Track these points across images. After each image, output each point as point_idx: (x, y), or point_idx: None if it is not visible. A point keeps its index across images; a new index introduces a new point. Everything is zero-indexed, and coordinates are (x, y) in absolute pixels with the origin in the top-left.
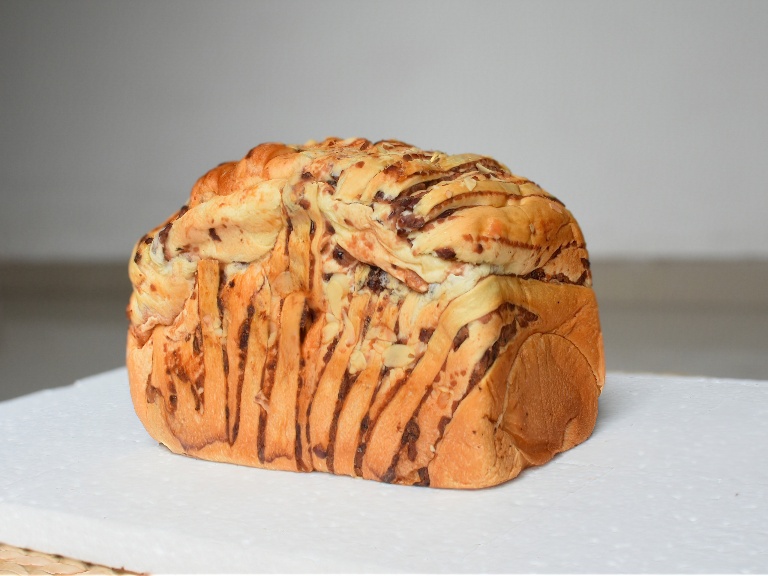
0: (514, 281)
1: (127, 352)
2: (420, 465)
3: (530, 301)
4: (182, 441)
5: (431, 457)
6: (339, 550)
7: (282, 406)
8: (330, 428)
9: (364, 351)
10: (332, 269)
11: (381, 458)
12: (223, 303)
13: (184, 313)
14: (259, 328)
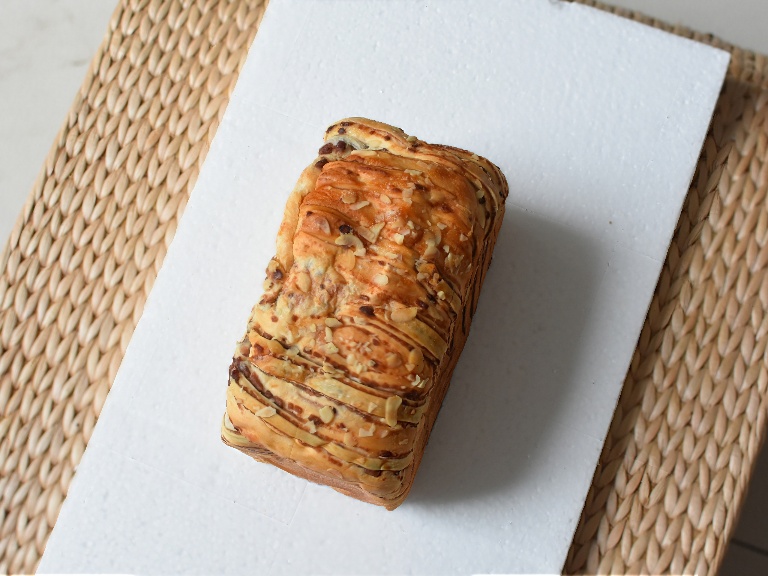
0: None
1: None
2: None
3: None
4: None
5: None
6: (129, 376)
7: None
8: None
9: None
10: None
11: None
12: None
13: None
14: None
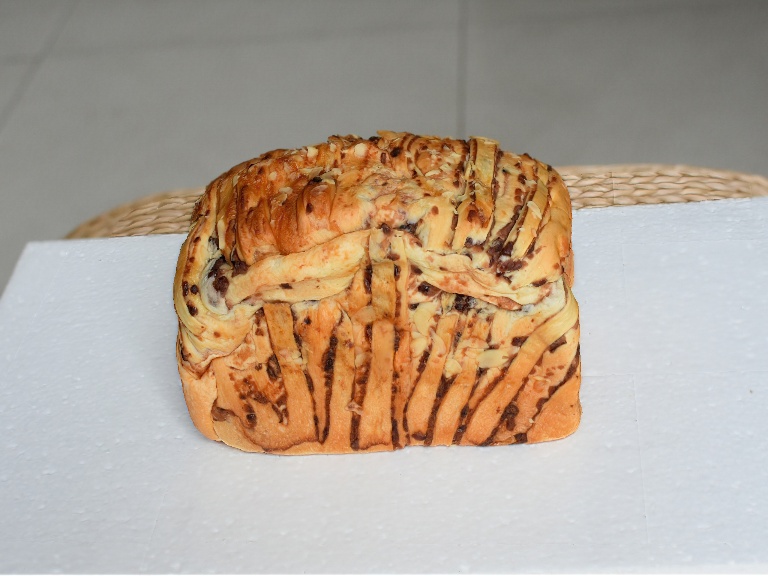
0: None
1: (185, 385)
2: (518, 432)
3: None
4: (265, 447)
5: (529, 426)
6: (549, 556)
7: (376, 409)
8: (429, 419)
9: (458, 359)
10: (419, 300)
11: (481, 433)
12: (301, 338)
13: (252, 348)
14: (346, 354)
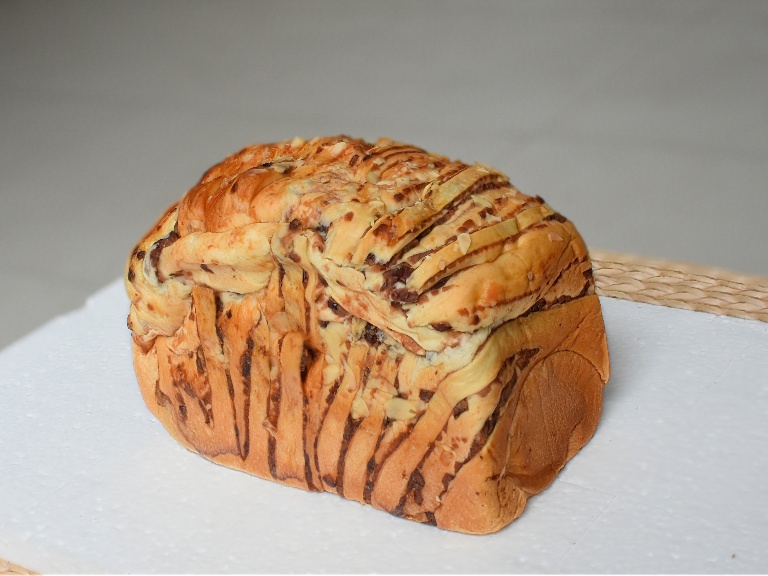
0: (513, 326)
1: None
2: (427, 509)
3: (531, 339)
4: (196, 447)
5: (437, 505)
6: None
7: (289, 435)
8: (338, 463)
9: (366, 399)
10: (328, 318)
11: (389, 497)
12: (222, 332)
13: (184, 332)
14: (260, 362)
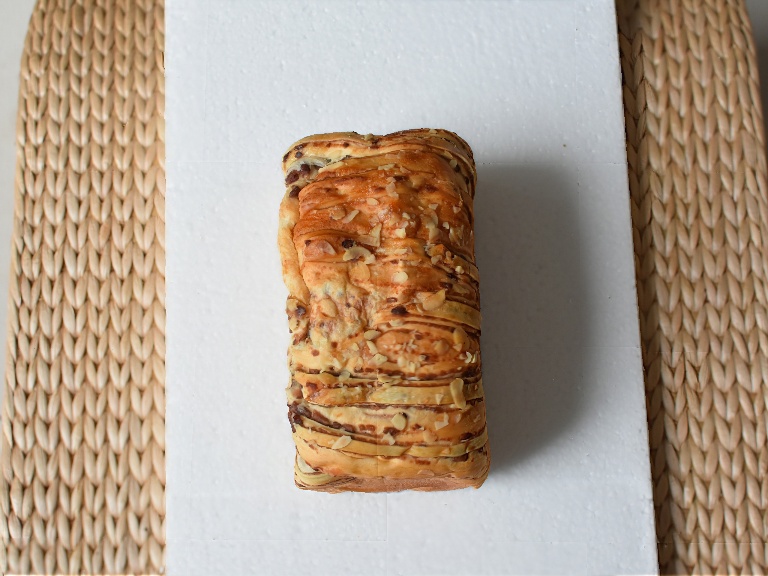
0: None
1: None
2: None
3: None
4: None
5: None
6: (179, 464)
7: None
8: None
9: None
10: None
11: None
12: None
13: None
14: None
